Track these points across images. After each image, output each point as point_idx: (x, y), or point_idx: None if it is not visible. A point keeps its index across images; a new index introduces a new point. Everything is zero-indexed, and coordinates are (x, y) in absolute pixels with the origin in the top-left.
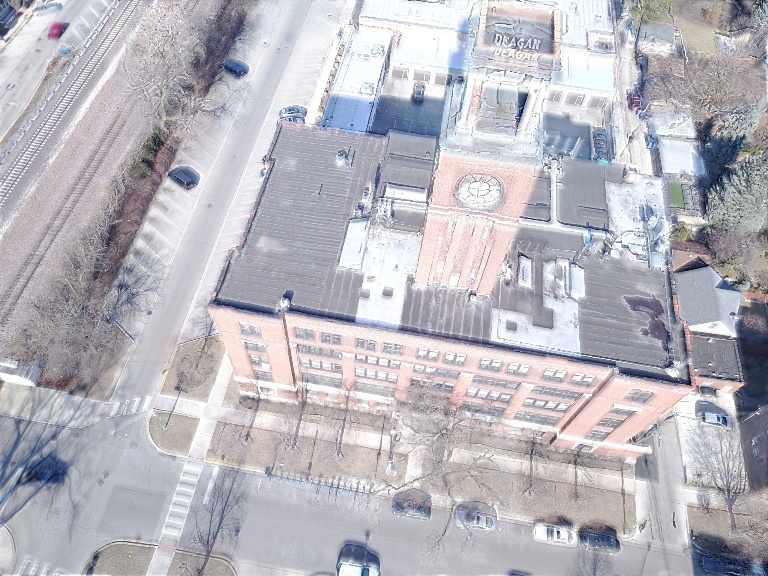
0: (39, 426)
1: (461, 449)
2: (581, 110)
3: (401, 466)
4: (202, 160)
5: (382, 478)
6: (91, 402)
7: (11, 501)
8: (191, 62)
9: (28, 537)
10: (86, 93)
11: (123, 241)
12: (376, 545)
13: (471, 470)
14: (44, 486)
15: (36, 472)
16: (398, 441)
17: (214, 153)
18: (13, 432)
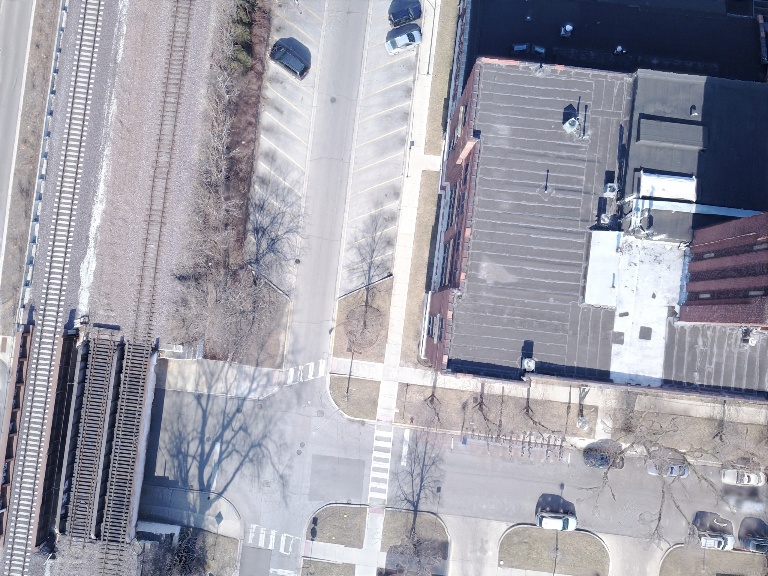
0: (220, 399)
1: (653, 397)
2: None
3: (591, 418)
4: (307, 24)
5: (573, 431)
6: (264, 371)
7: (220, 474)
8: None
9: (248, 505)
10: None
11: (244, 172)
12: (571, 493)
13: (687, 456)
14: (246, 459)
15: (233, 445)
16: (587, 392)
17: (320, 10)
18: (196, 407)
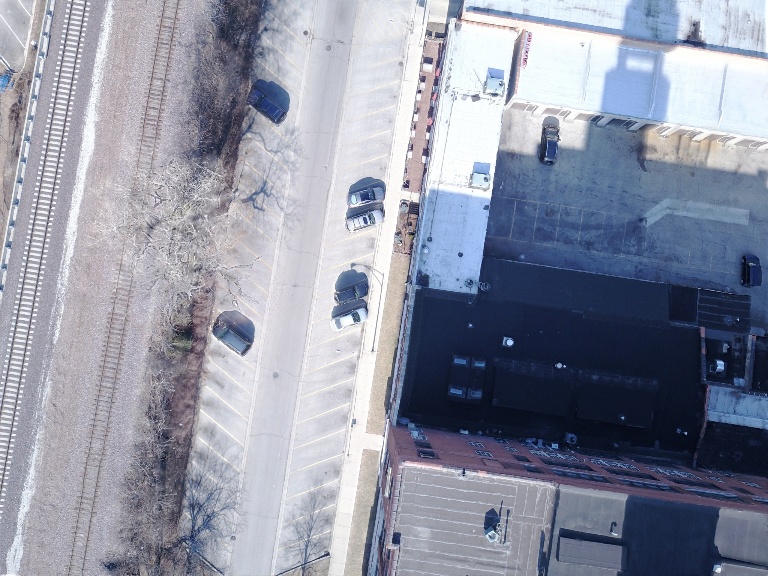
0: None
1: None
2: None
3: None
4: None
5: None
6: None
7: None
8: (202, 107)
9: None
10: (64, 201)
11: (181, 454)
12: None
13: None
14: None
15: None
16: None
17: (265, 282)
18: None
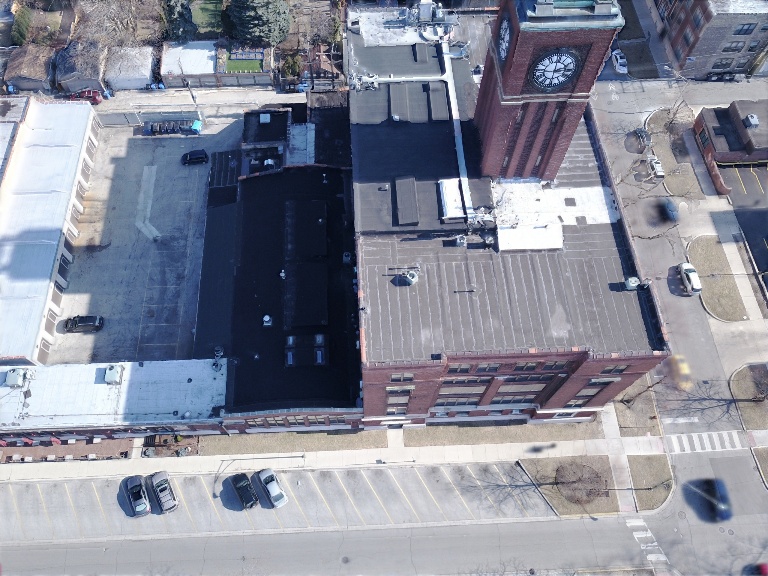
0: None
1: None
2: (105, 147)
3: None
4: None
5: None
6: None
7: None
8: None
9: None
10: None
11: None
12: None
13: None
14: None
15: None
16: None
17: None
18: None
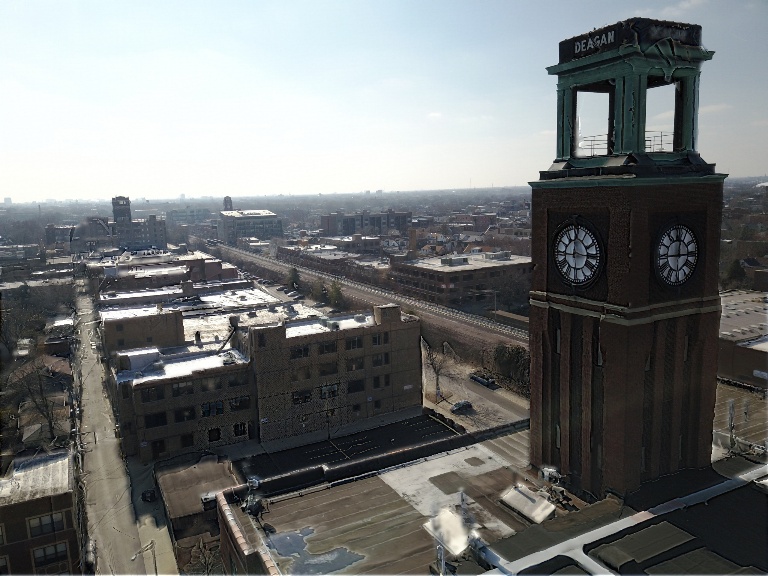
0: None
1: None
2: None
3: None
4: None
5: None
6: None
7: None
8: None
9: None
10: None
11: None
12: None
13: None
14: None
15: None
16: None
17: None
18: None
